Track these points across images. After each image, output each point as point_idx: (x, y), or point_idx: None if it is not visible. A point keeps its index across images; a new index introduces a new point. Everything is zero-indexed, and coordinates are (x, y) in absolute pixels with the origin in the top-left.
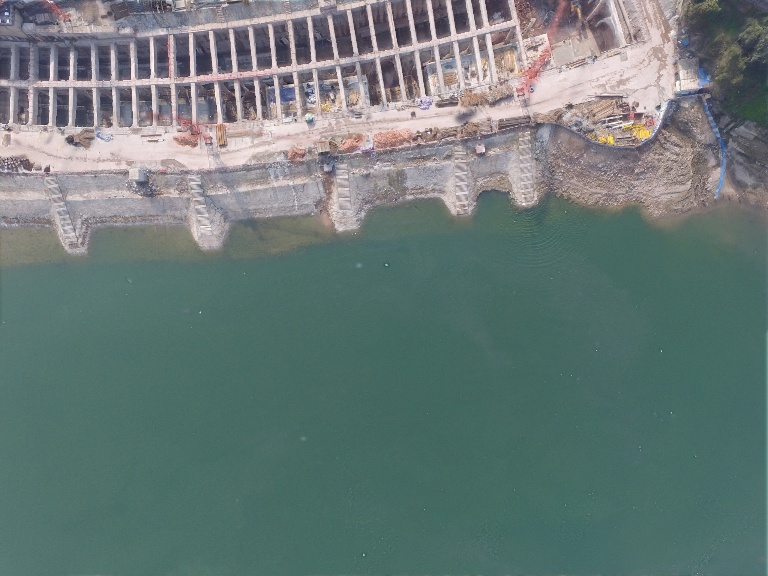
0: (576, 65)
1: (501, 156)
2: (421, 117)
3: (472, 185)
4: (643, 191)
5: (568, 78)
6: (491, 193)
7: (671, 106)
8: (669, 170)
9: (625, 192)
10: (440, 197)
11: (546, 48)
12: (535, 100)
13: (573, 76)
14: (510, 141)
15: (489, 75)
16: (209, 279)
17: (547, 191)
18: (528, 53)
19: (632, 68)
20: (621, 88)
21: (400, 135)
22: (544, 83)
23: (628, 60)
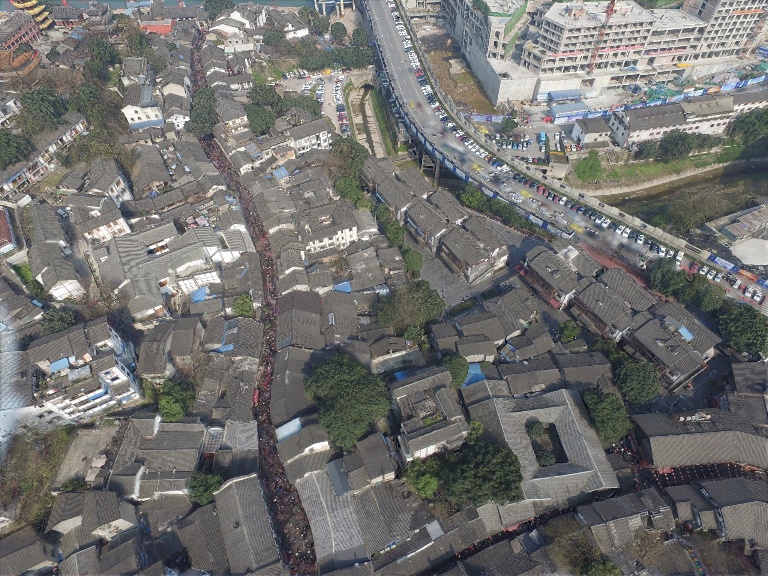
0: None
1: None
2: None
3: None
4: None
5: None
6: None
7: None
8: None
9: None
10: None
11: None
12: None
13: None
14: None
15: None
16: (178, 5)
17: None
18: None
19: None
20: None
21: None
22: None
23: None
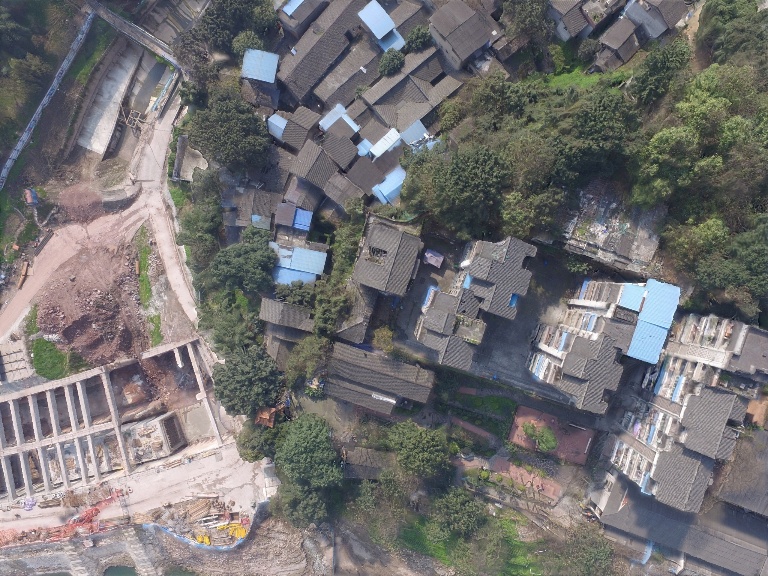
0: (173, 465)
1: (114, 544)
2: (26, 517)
3: (94, 566)
4: (260, 570)
5: (166, 478)
6: (119, 567)
7: (269, 502)
8: (279, 554)
9: (243, 570)
10: (69, 572)
11: (158, 435)
12: (135, 500)
13: (170, 476)
14: (118, 534)
15: (105, 461)
16: None
17: (172, 565)
18: (141, 440)
19: (227, 468)
20: (217, 487)
21: (4, 537)
22: (143, 483)
23: (223, 460)
